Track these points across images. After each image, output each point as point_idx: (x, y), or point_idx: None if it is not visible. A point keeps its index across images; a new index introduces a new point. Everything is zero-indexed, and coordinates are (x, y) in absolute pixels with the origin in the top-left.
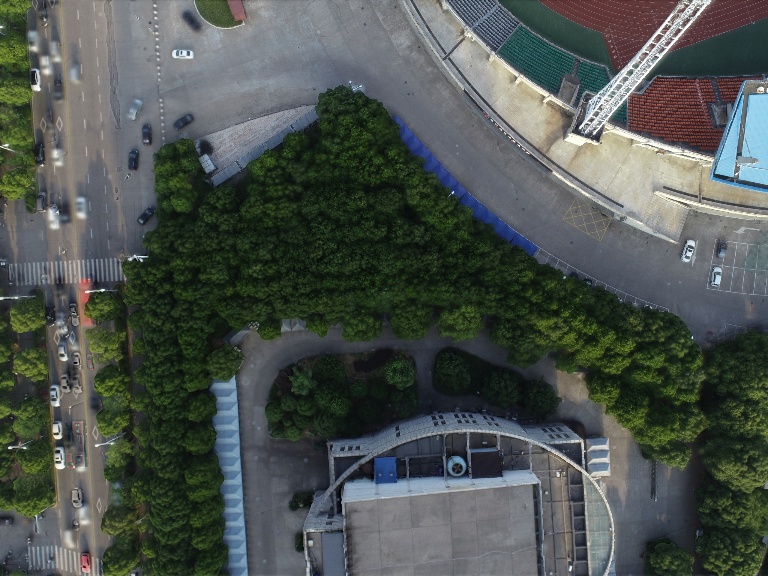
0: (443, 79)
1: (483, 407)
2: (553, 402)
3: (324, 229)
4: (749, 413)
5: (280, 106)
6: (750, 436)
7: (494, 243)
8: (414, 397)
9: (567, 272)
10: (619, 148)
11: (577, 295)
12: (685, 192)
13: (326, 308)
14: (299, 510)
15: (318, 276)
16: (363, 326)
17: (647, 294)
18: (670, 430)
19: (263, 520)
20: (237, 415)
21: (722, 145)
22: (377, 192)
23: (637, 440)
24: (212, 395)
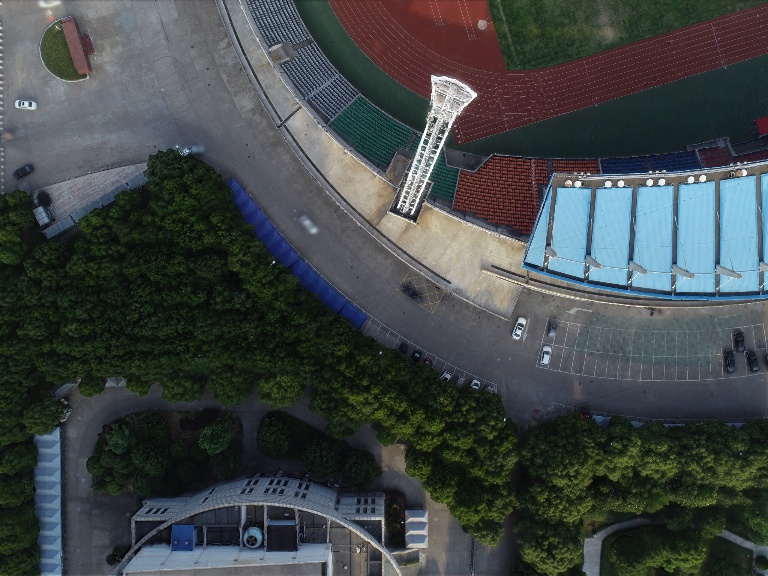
0: (284, 144)
1: (307, 472)
2: (369, 474)
3: (142, 292)
4: (552, 499)
5: (121, 161)
6: (553, 522)
7: (313, 314)
8: (232, 461)
9: (398, 342)
10: (449, 224)
11: (390, 372)
12: (513, 272)
13: (140, 370)
14: (118, 564)
15: (134, 338)
16: (178, 389)
17: (476, 369)
18: (474, 511)
19: (83, 571)
20: (59, 467)
21: (532, 234)
22: (198, 257)
23: (452, 515)
24: (33, 447)
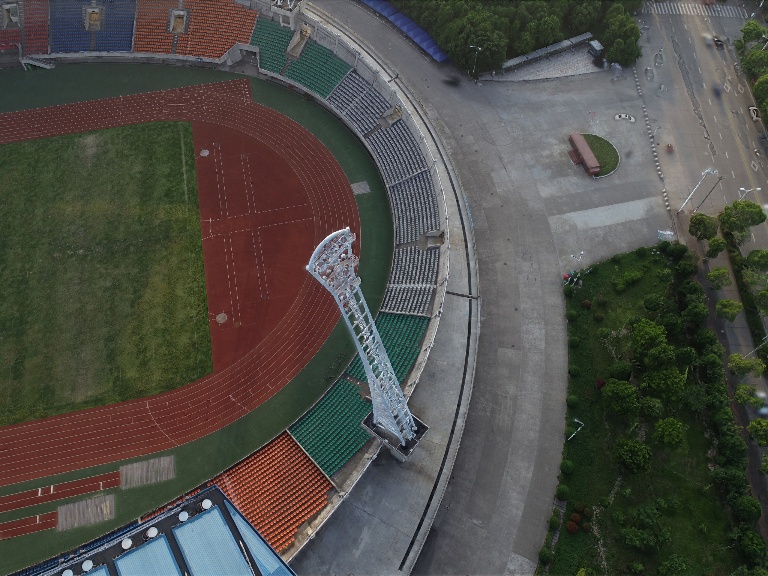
0: None
1: None
2: None
3: None
4: None
5: (537, 83)
6: None
7: None
8: None
9: None
10: None
11: None
12: None
13: None
14: None
15: None
16: None
17: None
18: None
19: None
20: None
21: None
22: None
23: None
24: None
